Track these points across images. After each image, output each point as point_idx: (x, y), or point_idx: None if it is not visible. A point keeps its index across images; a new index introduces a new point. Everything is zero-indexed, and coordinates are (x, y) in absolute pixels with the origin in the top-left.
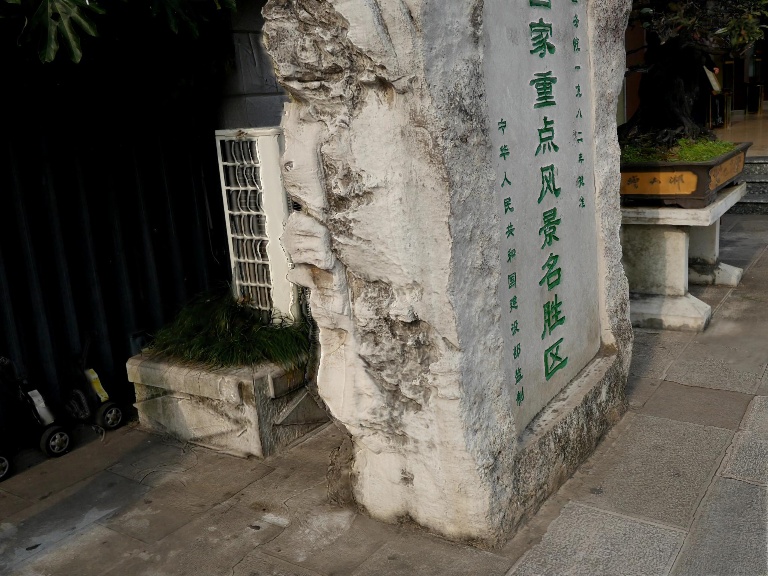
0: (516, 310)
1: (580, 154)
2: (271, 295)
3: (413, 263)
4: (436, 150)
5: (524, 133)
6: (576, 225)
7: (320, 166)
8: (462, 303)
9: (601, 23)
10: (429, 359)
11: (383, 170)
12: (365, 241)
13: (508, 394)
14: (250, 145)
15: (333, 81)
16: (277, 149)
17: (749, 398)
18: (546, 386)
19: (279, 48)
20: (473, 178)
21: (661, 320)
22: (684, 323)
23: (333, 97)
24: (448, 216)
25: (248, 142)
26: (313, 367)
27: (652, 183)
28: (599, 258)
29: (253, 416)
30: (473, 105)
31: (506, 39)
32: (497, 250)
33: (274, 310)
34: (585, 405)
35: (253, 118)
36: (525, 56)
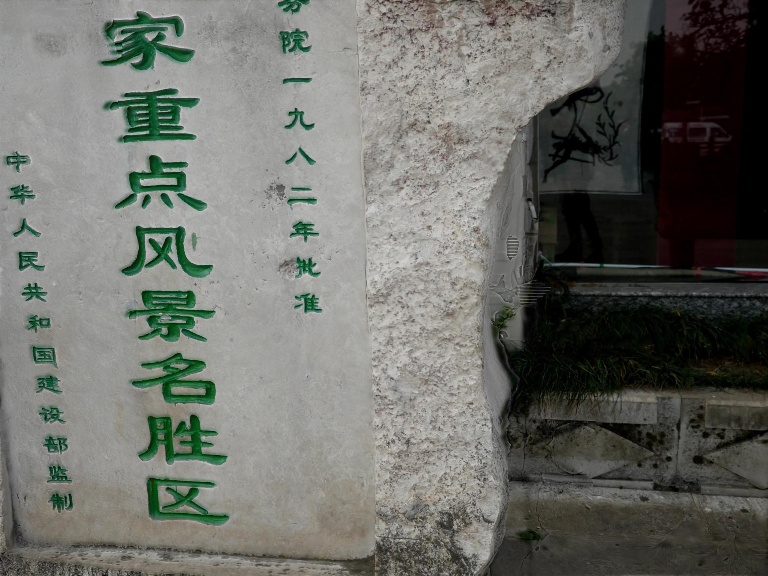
0: (58, 395)
1: (304, 224)
2: None
3: None
4: None
5: None
6: (280, 334)
7: None
8: None
9: None
10: None
11: None
12: None
13: (1, 480)
14: None
15: None
16: None
17: None
18: (148, 525)
19: None
20: None
21: None
22: None
23: None
24: None
25: None
26: None
27: None
28: None
29: None
30: None
31: (38, 49)
32: None
33: None
34: None
35: None
36: (87, 70)
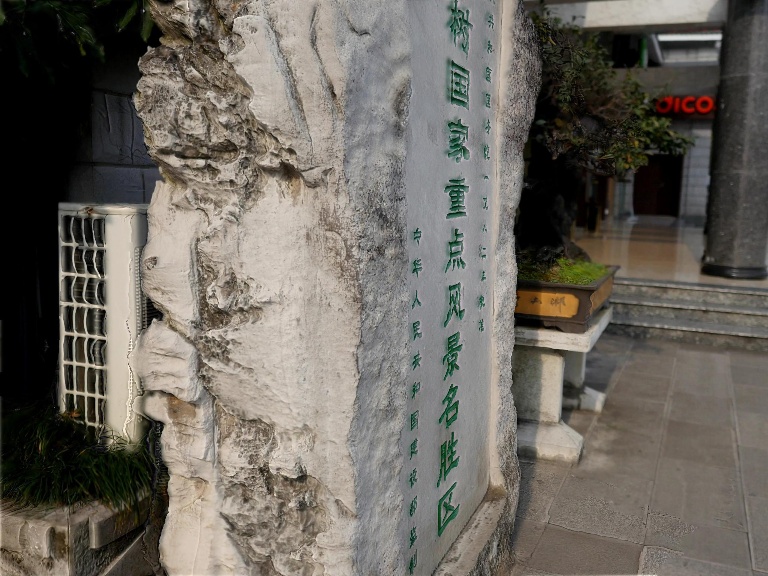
0: (416, 456)
1: (483, 272)
2: (102, 408)
3: (306, 402)
4: (350, 262)
5: (436, 246)
6: (475, 351)
7: (193, 267)
8: (363, 455)
9: (509, 133)
10: (314, 525)
11: (278, 281)
12: (245, 369)
13: (404, 564)
14: (94, 224)
15: (222, 161)
16: (129, 232)
17: (639, 549)
18: (438, 543)
19: (154, 111)
20: (387, 298)
21: (535, 448)
22: (559, 453)
23: (220, 181)
24: (357, 346)
25: (92, 220)
26: (156, 526)
27: (533, 303)
28: (493, 387)
29: (63, 573)
30: (393, 210)
31: (427, 137)
32: (405, 386)
33: (104, 427)
34: (479, 565)
35: (100, 191)
36: (443, 159)
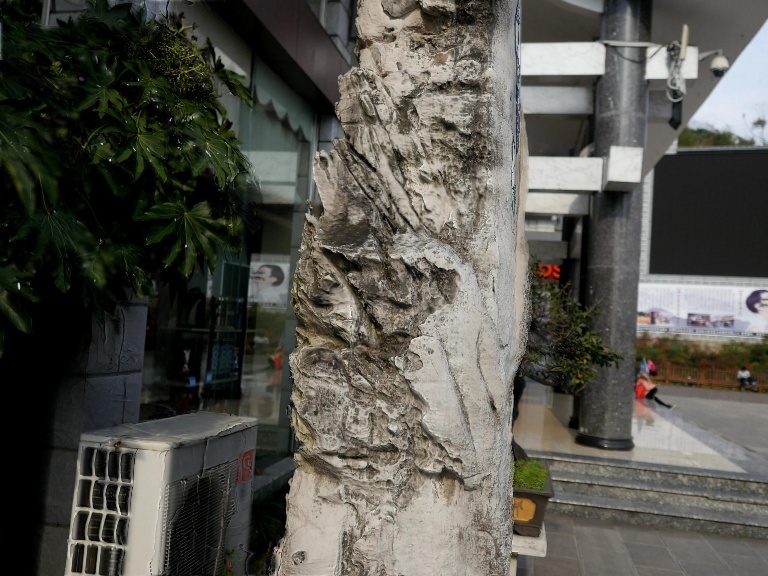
0: None
1: None
2: None
3: None
4: (498, 560)
5: None
6: None
7: (339, 561)
8: None
9: None
10: None
11: None
12: None
13: None
14: (123, 458)
15: (381, 462)
16: (162, 469)
17: None
18: None
19: (321, 414)
20: None
21: None
22: None
23: (378, 481)
24: None
25: (120, 454)
26: None
27: None
28: None
29: None
30: None
31: None
32: None
33: None
34: None
35: (90, 403)
36: None
